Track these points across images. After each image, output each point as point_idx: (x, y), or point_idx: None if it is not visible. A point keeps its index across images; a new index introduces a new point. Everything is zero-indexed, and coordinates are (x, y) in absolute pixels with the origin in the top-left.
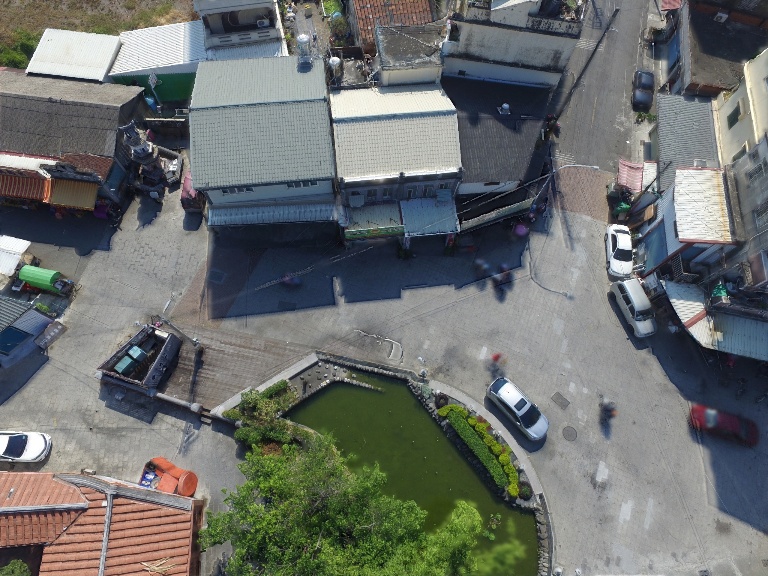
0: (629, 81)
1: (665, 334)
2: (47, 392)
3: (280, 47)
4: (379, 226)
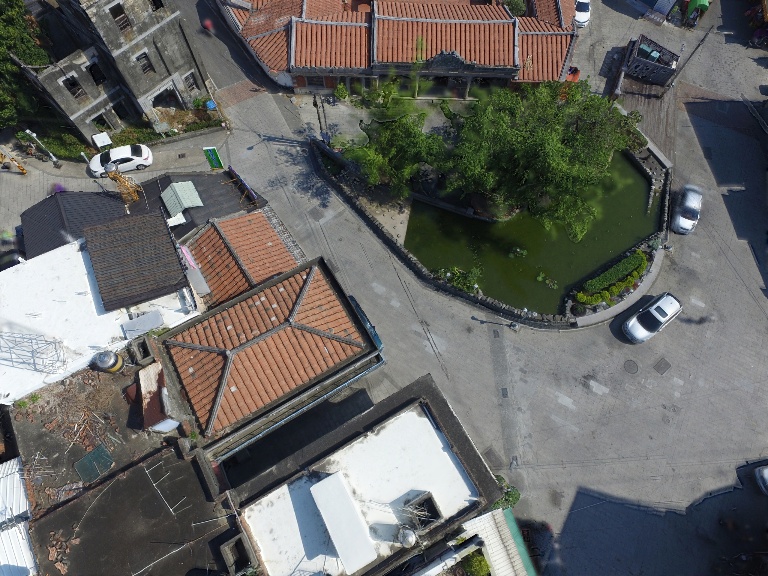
0: None
1: (764, 514)
2: (613, 22)
3: None
4: None
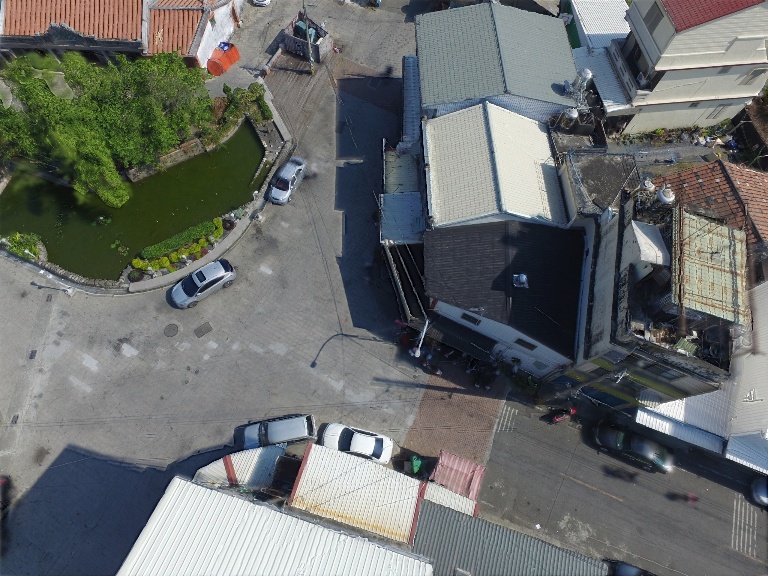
0: (668, 575)
1: None
2: (299, 2)
3: (620, 103)
4: (395, 175)
